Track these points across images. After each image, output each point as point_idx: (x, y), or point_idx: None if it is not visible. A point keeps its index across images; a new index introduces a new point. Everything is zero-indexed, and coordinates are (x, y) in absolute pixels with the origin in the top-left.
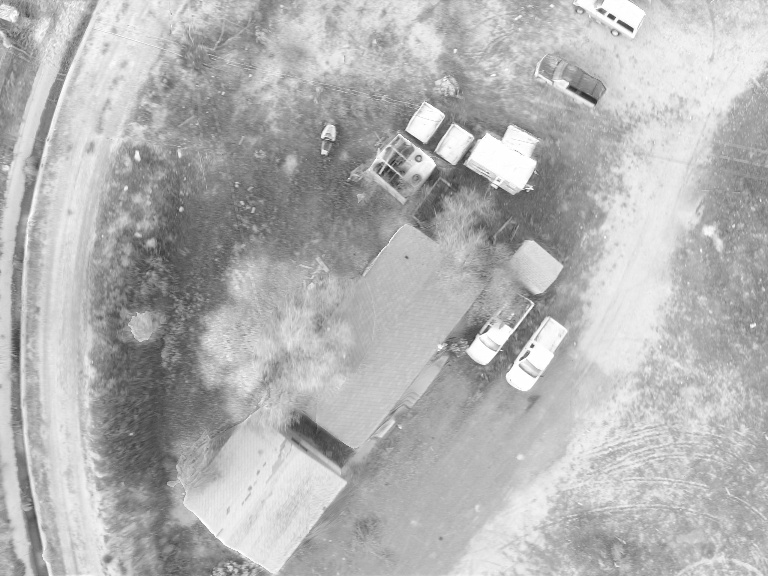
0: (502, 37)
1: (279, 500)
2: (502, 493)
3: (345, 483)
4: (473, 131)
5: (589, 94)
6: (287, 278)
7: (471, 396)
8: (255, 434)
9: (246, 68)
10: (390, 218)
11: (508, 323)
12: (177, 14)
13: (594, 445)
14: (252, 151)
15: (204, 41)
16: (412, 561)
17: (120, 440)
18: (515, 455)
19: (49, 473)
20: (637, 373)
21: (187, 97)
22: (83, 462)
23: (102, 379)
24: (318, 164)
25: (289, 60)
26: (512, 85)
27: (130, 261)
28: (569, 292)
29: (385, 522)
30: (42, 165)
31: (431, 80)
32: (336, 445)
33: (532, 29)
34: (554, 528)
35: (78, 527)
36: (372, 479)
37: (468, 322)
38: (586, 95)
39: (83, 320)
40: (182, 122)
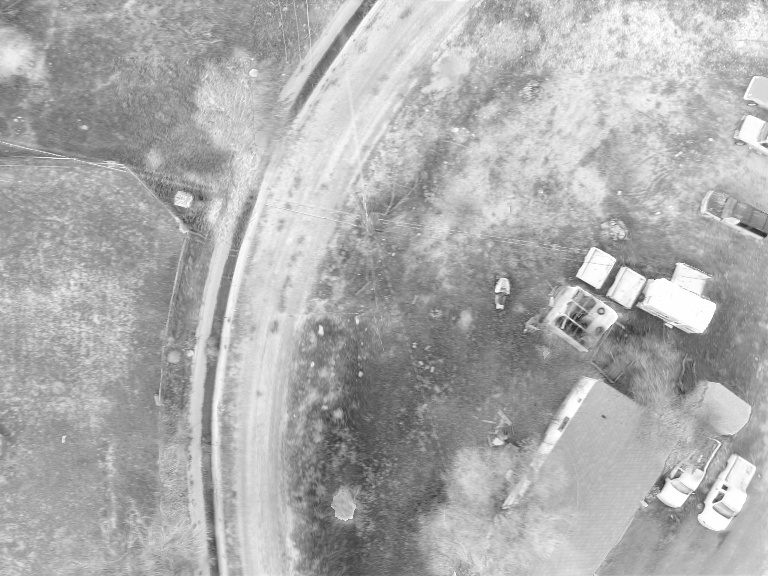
0: (664, 174)
1: None
2: None
3: None
4: (643, 272)
5: (760, 229)
6: (471, 435)
7: (663, 538)
8: None
9: (415, 227)
10: (568, 366)
11: (699, 466)
12: (350, 185)
13: None
14: (426, 310)
15: (376, 208)
16: None
17: None
18: None
19: None
20: None
21: (361, 264)
22: None
23: (306, 560)
24: (494, 319)
25: (456, 215)
26: (677, 221)
27: (321, 437)
28: (749, 425)
29: None
30: (225, 346)
31: (597, 223)
32: None
33: (693, 164)
34: None
35: None
36: None
37: (664, 472)
38: (756, 230)
39: (281, 502)
40: (359, 290)
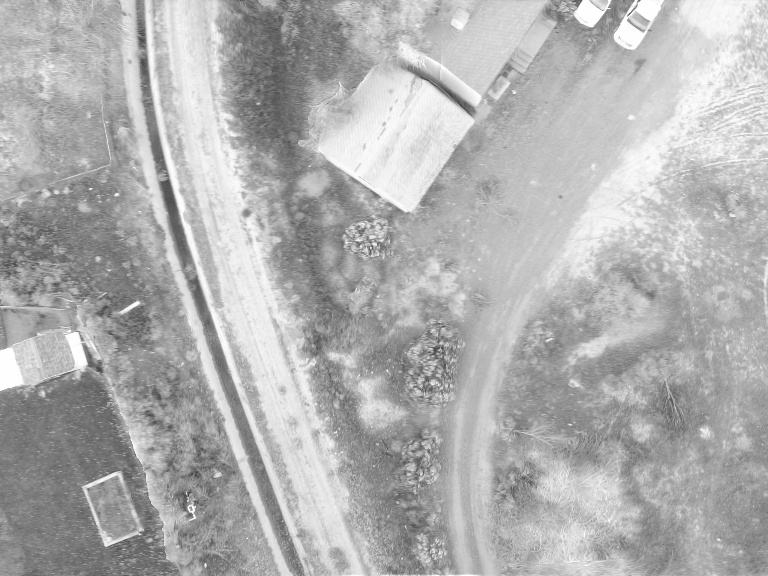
0: None
1: (413, 134)
2: (616, 152)
3: (473, 121)
4: None
5: None
6: None
7: (580, 61)
8: (384, 77)
9: None
10: None
11: None
12: None
13: (701, 105)
14: None
15: None
16: (534, 220)
17: (249, 106)
18: (626, 116)
19: (184, 138)
20: (738, 36)
21: None
22: (216, 125)
23: (230, 44)
24: None
25: None
26: None
27: None
28: None
29: (506, 183)
30: None
31: None
32: (458, 98)
33: None
34: (669, 184)
35: (215, 187)
36: (491, 143)
37: None
38: None
39: None
40: None
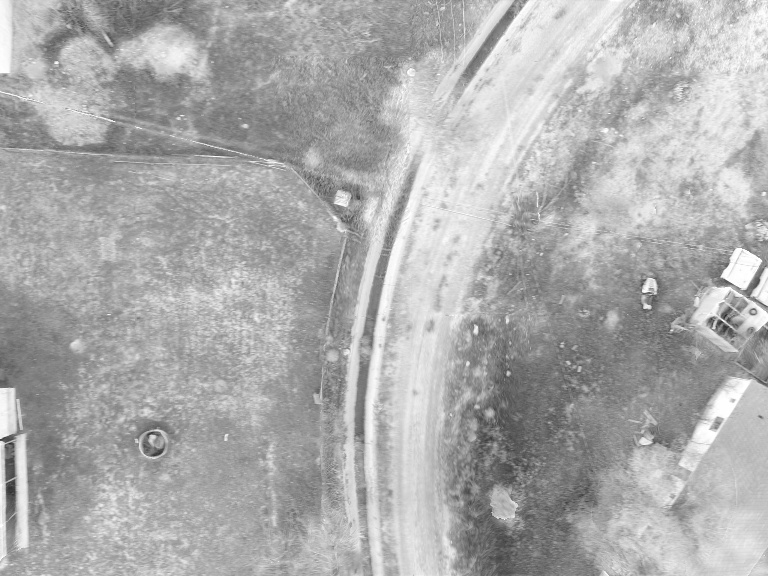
0: None
1: None
2: None
3: None
4: None
5: None
6: (617, 434)
7: None
8: None
9: (562, 227)
10: (712, 366)
11: None
12: (506, 185)
13: None
14: (574, 310)
15: (529, 208)
16: None
17: None
18: None
19: None
20: None
21: (513, 264)
22: None
23: (462, 558)
24: (641, 319)
25: (603, 216)
26: None
27: None
28: None
29: None
30: (380, 345)
31: (741, 224)
32: None
33: None
34: None
35: None
36: None
37: None
38: None
39: (438, 500)
40: (510, 289)
